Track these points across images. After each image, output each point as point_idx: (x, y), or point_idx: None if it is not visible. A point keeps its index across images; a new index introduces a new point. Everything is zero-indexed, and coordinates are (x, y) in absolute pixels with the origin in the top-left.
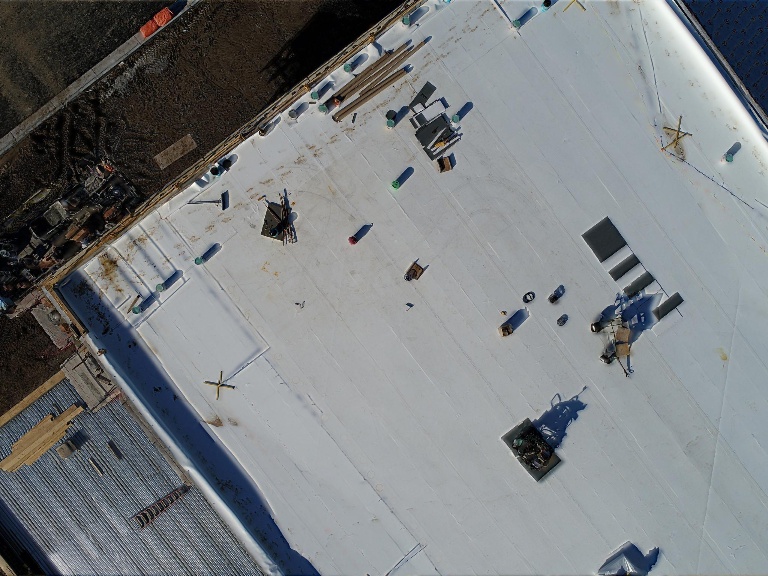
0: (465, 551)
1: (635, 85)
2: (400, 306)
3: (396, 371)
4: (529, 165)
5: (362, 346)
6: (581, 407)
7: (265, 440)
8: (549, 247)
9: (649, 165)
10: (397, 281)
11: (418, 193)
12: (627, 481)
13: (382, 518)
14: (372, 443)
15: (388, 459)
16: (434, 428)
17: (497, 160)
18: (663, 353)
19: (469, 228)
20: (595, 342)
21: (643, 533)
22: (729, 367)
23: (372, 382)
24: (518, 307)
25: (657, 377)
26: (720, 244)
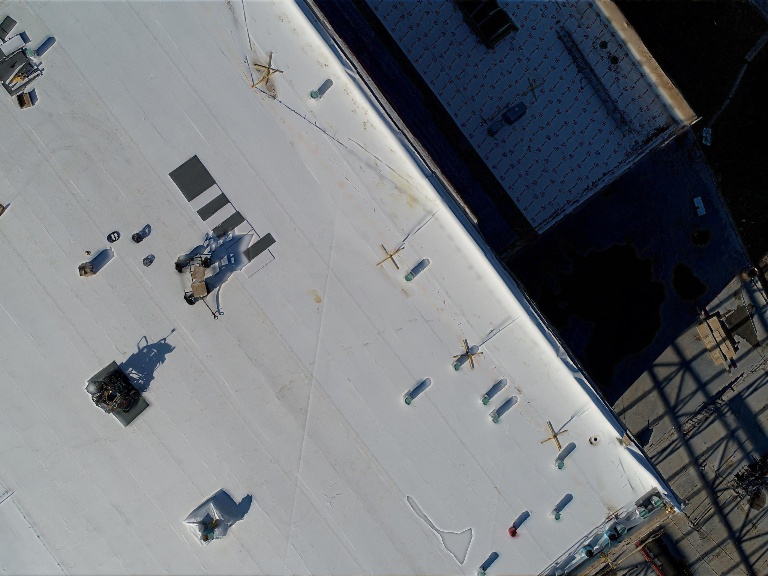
0: (54, 498)
1: (224, 21)
2: None
3: None
4: (114, 102)
5: None
6: (170, 350)
7: None
8: (135, 186)
9: (239, 103)
10: None
11: None
12: (218, 426)
13: None
14: None
15: None
16: (19, 371)
17: (80, 96)
18: (255, 295)
19: (51, 166)
20: (184, 283)
21: (235, 480)
22: (324, 310)
23: None
24: (103, 247)
25: (249, 320)
26: (313, 184)
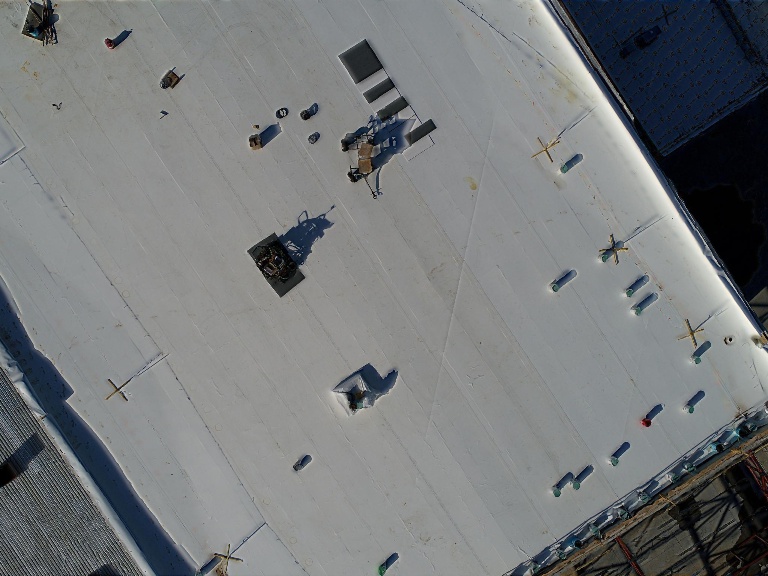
0: (207, 363)
1: None
2: (155, 114)
3: (148, 178)
4: None
5: (116, 151)
6: (328, 226)
7: (16, 239)
8: (306, 65)
9: None
10: (153, 88)
11: (178, 2)
12: (370, 303)
13: (127, 324)
14: (121, 249)
15: (136, 266)
16: (182, 237)
17: None
18: (413, 178)
19: (227, 40)
20: (346, 162)
21: (383, 356)
22: (478, 197)
23: (124, 188)
24: (271, 122)
25: (406, 202)
26: (476, 75)
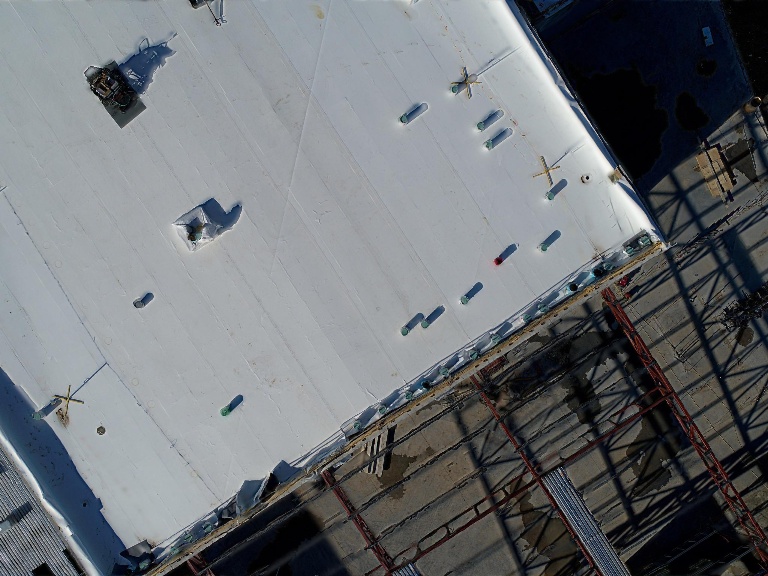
0: (46, 197)
1: None
2: None
3: None
4: None
5: None
6: (170, 55)
7: None
8: None
9: None
10: None
11: None
12: (213, 134)
13: None
14: None
15: None
16: (20, 66)
17: None
18: (258, 6)
19: None
20: None
21: (227, 190)
22: (326, 27)
23: None
24: None
25: (251, 31)
26: None
